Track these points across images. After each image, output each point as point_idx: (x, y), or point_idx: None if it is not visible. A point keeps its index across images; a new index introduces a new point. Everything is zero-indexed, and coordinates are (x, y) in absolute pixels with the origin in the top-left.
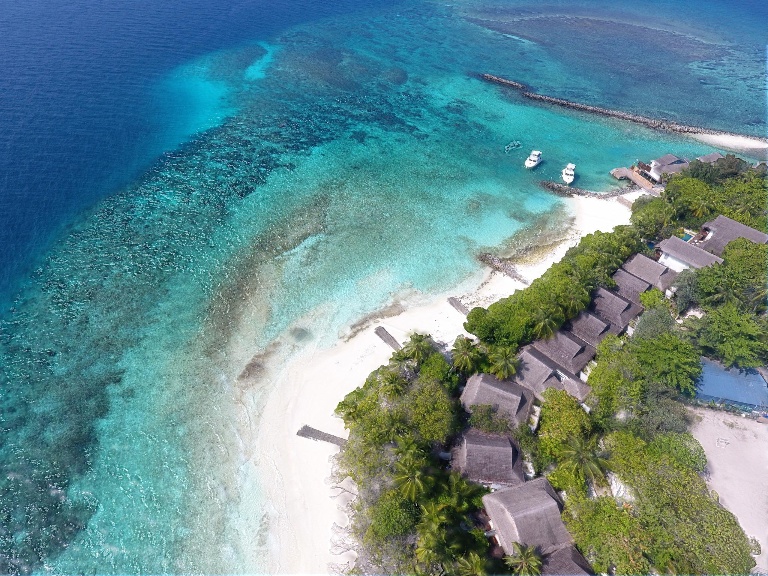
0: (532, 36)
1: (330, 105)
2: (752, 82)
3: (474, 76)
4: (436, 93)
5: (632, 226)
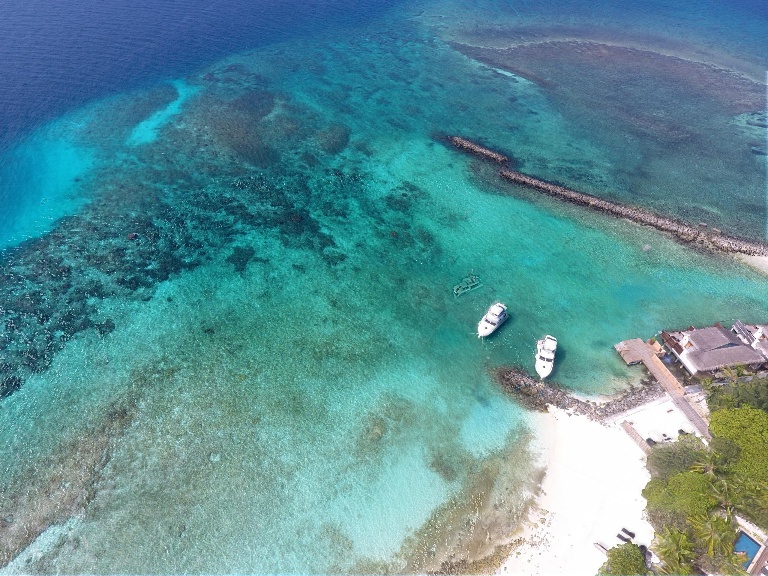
0: (530, 72)
1: (222, 193)
2: None
3: (440, 139)
4: (379, 171)
5: None
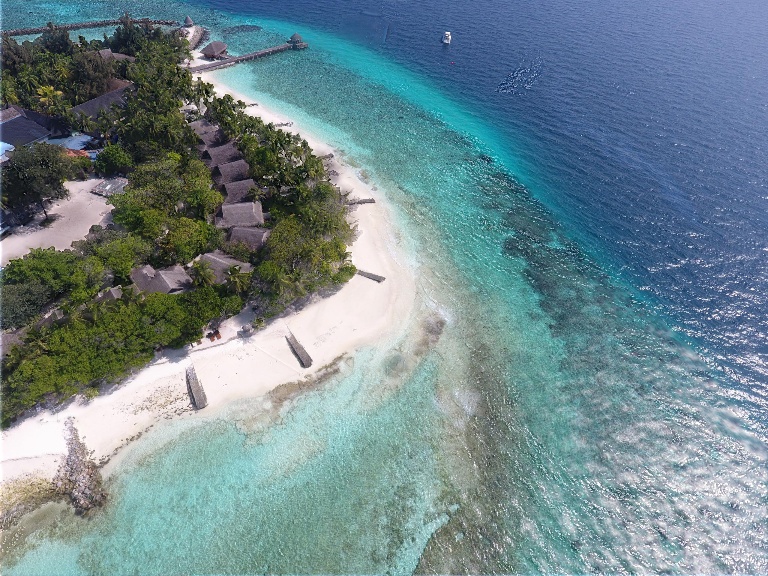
0: None
1: None
2: None
3: None
4: None
5: None
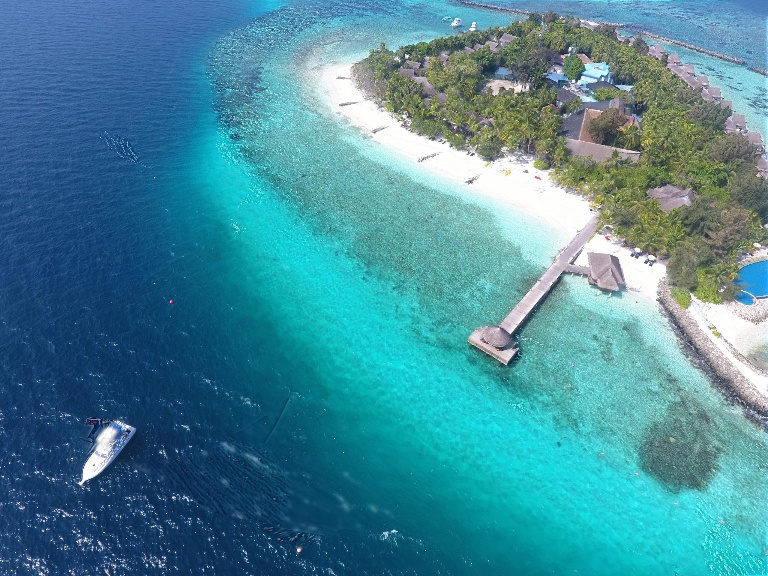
0: None
1: (343, 3)
2: (613, 2)
3: None
4: (408, 1)
5: (487, 30)
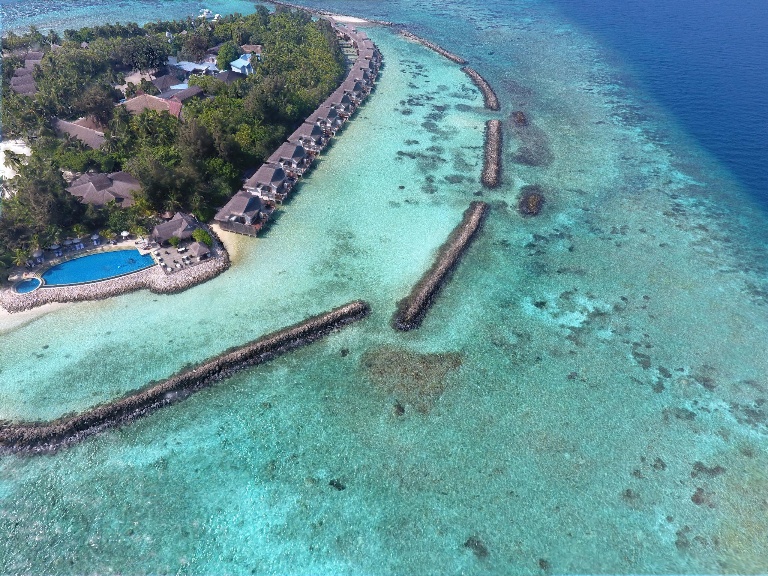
0: None
1: None
2: (423, 2)
3: None
4: None
5: None
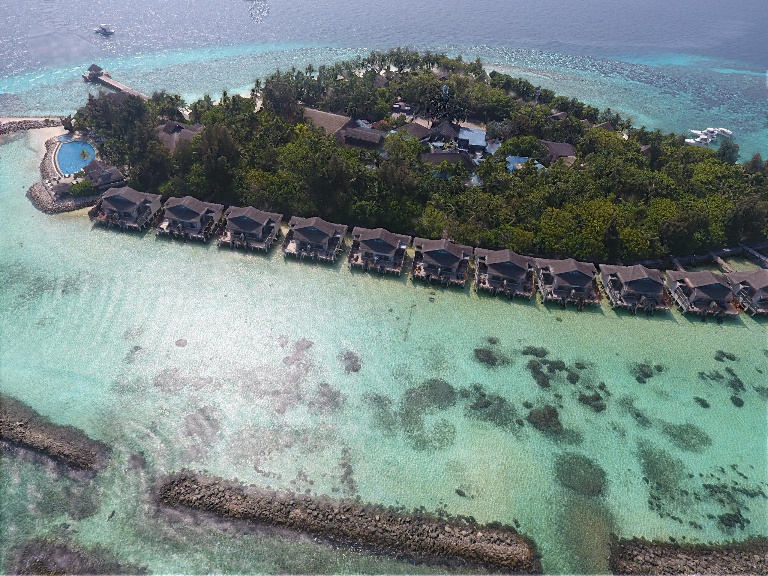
0: None
1: None
2: None
3: None
4: None
5: None
